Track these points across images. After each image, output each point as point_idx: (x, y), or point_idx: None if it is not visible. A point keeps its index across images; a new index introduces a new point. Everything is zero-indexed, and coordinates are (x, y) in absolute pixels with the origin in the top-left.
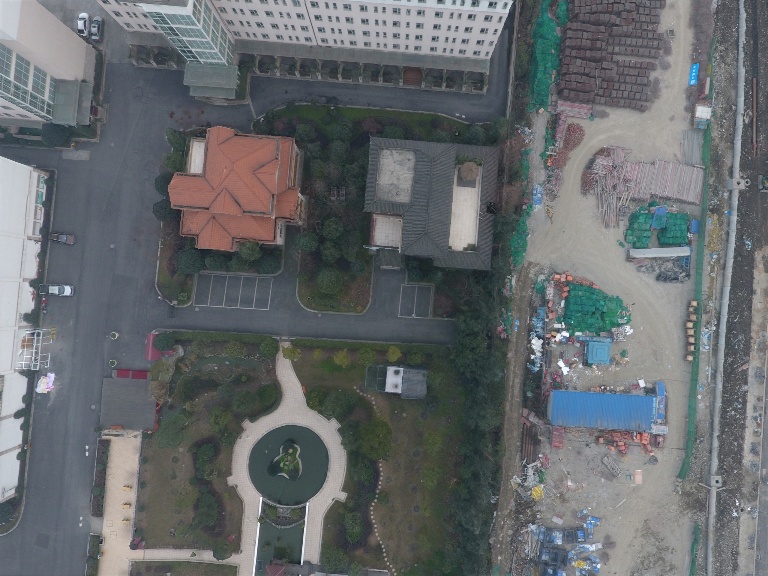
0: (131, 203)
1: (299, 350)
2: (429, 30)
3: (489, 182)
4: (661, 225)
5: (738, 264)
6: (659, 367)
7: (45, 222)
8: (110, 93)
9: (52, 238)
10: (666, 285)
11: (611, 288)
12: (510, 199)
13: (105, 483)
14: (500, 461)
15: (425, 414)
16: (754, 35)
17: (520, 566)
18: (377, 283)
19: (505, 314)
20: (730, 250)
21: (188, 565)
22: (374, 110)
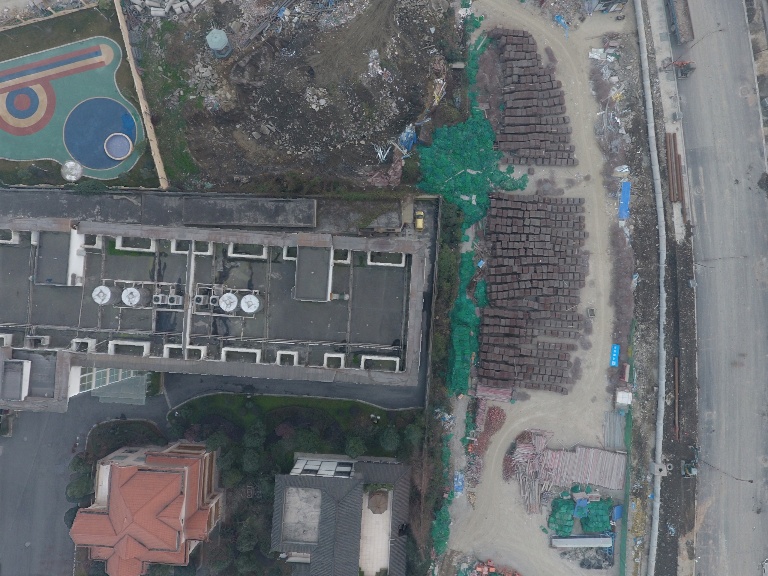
0: (46, 499)
1: None
2: None
3: (400, 505)
4: (583, 515)
5: (662, 550)
6: None
7: None
8: None
9: None
10: (590, 571)
11: (535, 575)
12: (429, 496)
13: None
14: None
15: None
16: (675, 312)
17: None
18: None
19: None
20: (653, 538)
21: None
22: (291, 398)
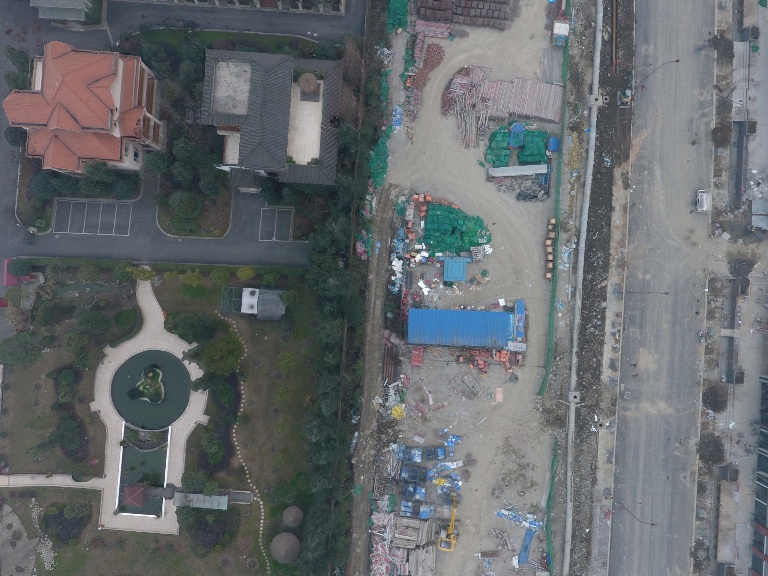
0: None
1: (153, 272)
2: None
3: (332, 96)
4: (519, 143)
5: (597, 181)
6: (520, 286)
7: None
8: None
9: None
10: (526, 204)
11: (472, 208)
12: (365, 118)
13: None
14: (359, 380)
15: (286, 337)
16: None
17: (382, 485)
18: (237, 207)
19: (365, 236)
20: (589, 167)
21: (53, 490)
22: (232, 33)
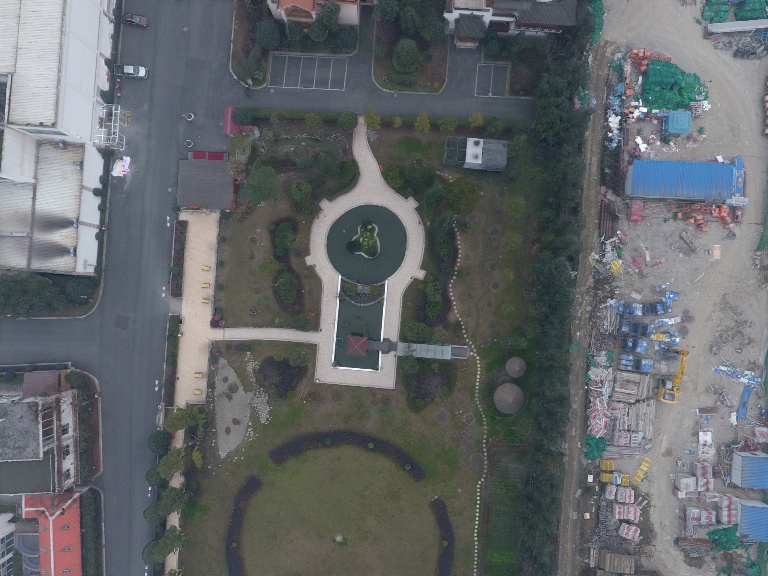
0: None
1: None
2: None
3: None
4: None
5: None
6: (737, 143)
7: (117, 4)
8: None
9: (126, 18)
10: (743, 62)
11: (688, 66)
12: None
13: (183, 264)
14: None
15: (503, 192)
16: None
17: (599, 341)
18: (453, 63)
19: (582, 92)
20: None
21: (268, 344)
22: None
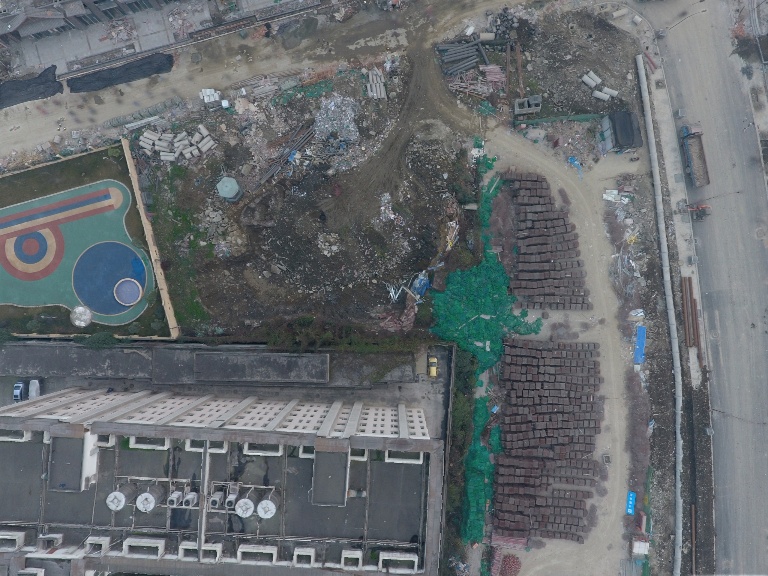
0: None
1: None
2: None
3: None
4: None
5: None
6: None
7: None
8: None
9: None
10: None
11: None
12: None
13: None
14: None
15: None
16: (692, 458)
17: None
18: None
19: None
20: None
21: None
22: None
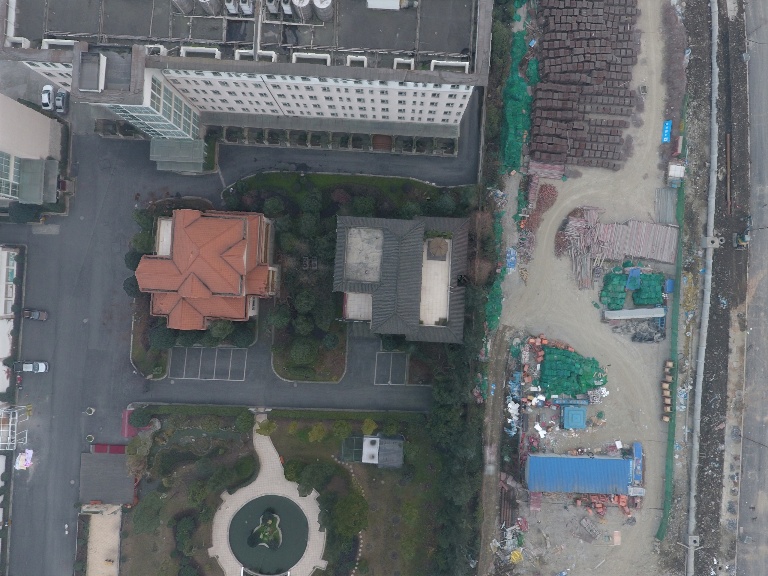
0: (103, 276)
1: (275, 424)
2: (394, 104)
3: (459, 255)
4: (635, 286)
5: (713, 323)
6: (636, 428)
7: (17, 299)
8: (77, 165)
9: (24, 315)
10: (642, 345)
11: (587, 350)
12: (483, 265)
13: (87, 557)
14: (478, 527)
15: (403, 481)
16: (727, 89)
17: None
18: (352, 351)
19: (481, 379)
20: (705, 309)
21: None
22: (344, 176)
